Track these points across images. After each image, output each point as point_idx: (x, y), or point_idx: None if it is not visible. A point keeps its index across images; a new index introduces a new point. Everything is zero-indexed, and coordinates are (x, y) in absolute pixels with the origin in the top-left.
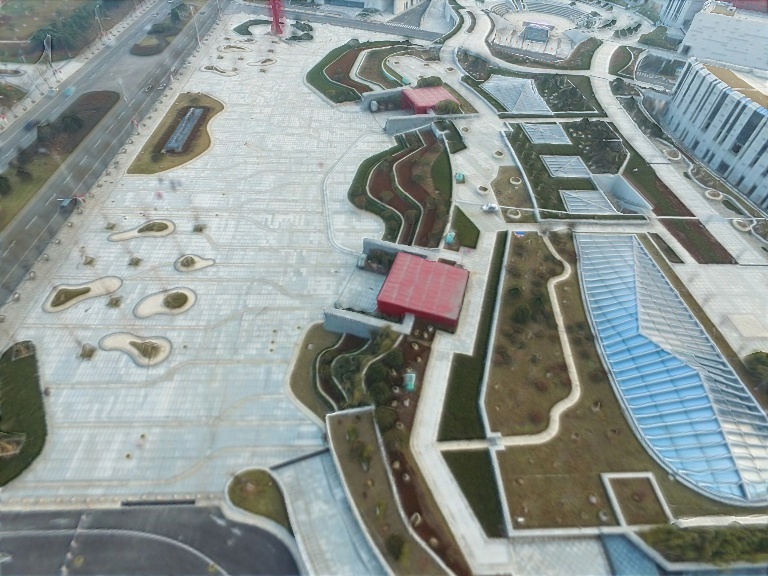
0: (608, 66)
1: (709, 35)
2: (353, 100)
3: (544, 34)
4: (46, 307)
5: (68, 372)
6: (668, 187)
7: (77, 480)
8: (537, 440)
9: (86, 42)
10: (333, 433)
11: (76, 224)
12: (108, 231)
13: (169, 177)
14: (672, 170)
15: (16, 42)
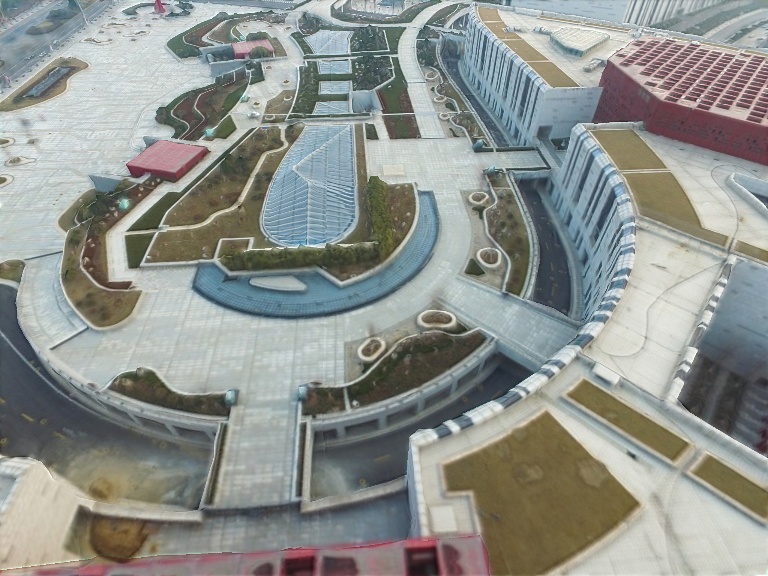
0: (429, 19)
1: None
2: (197, 55)
3: None
4: None
5: None
6: (409, 97)
7: None
8: (191, 227)
9: None
10: (68, 237)
11: None
12: None
13: (22, 112)
14: (423, 86)
15: None
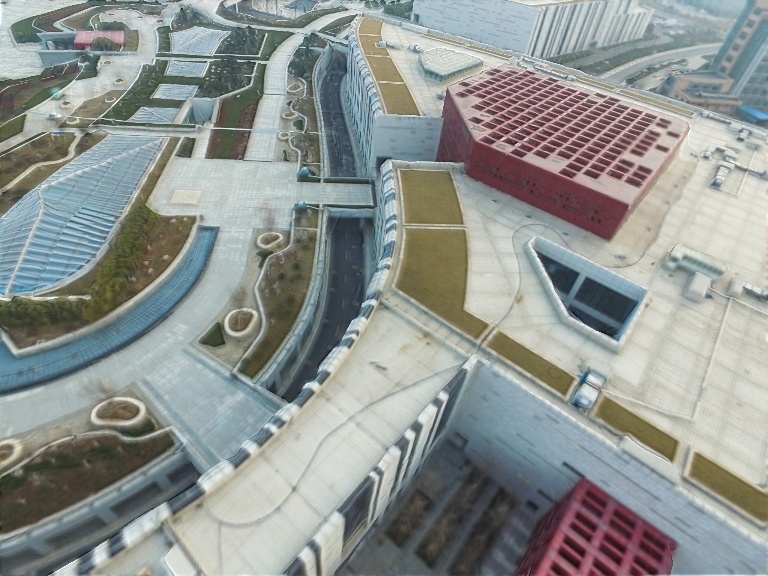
0: (323, 26)
1: (429, 4)
2: (38, 41)
3: (312, 5)
4: None
5: None
6: (257, 110)
7: None
8: None
9: None
10: None
11: None
12: None
13: None
14: (280, 99)
15: None
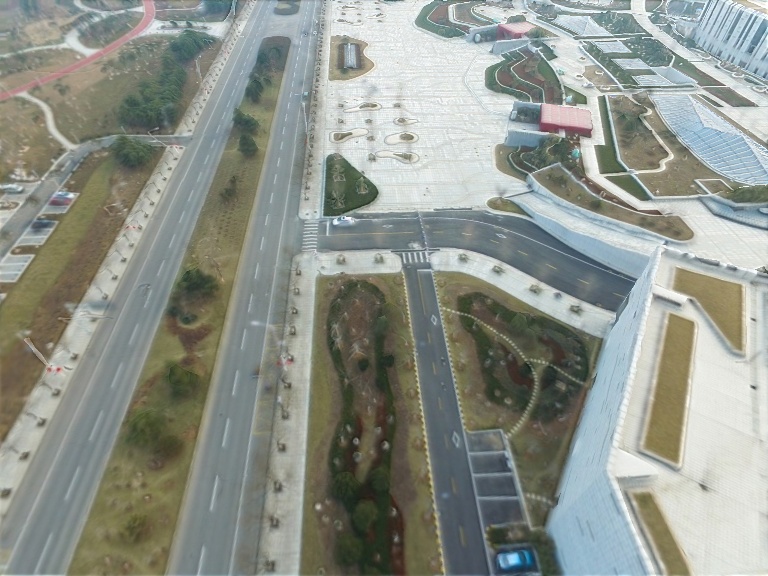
0: (644, 7)
1: None
2: (459, 36)
3: None
4: (333, 141)
5: (367, 166)
6: (705, 73)
7: (404, 203)
8: (655, 171)
9: (241, 7)
10: (537, 179)
11: (318, 105)
12: (341, 108)
13: (360, 81)
14: (706, 64)
15: (187, 9)
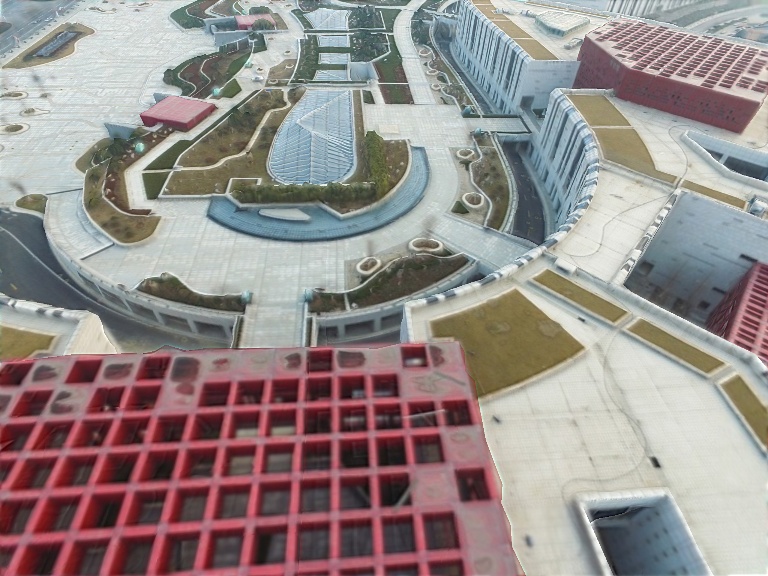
0: (423, 3)
1: None
2: (200, 27)
3: None
4: None
5: None
6: (404, 69)
7: None
8: (204, 168)
9: None
10: (87, 175)
11: None
12: None
13: (33, 70)
14: (417, 61)
15: None
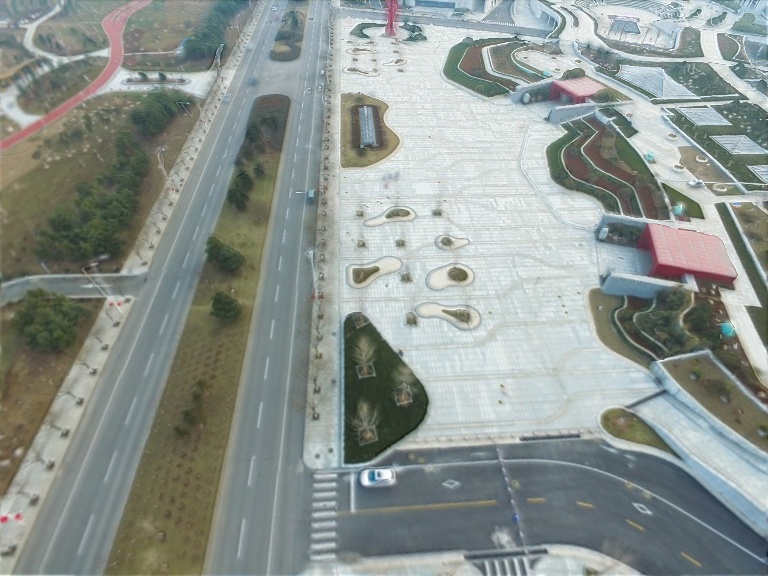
0: (720, 53)
1: None
2: (502, 94)
3: (634, 26)
4: (351, 284)
5: (405, 337)
6: None
7: (470, 422)
8: None
9: (229, 50)
10: (674, 375)
11: (328, 213)
12: (360, 218)
13: (383, 169)
14: None
15: (163, 53)
